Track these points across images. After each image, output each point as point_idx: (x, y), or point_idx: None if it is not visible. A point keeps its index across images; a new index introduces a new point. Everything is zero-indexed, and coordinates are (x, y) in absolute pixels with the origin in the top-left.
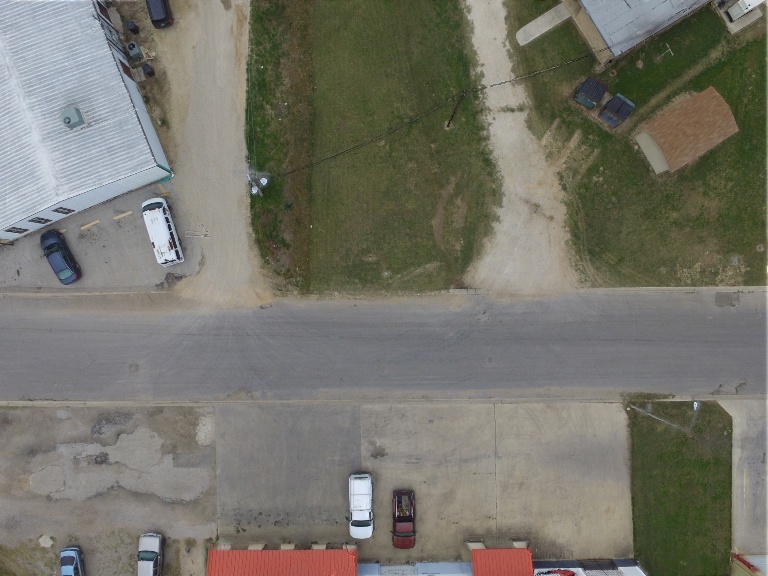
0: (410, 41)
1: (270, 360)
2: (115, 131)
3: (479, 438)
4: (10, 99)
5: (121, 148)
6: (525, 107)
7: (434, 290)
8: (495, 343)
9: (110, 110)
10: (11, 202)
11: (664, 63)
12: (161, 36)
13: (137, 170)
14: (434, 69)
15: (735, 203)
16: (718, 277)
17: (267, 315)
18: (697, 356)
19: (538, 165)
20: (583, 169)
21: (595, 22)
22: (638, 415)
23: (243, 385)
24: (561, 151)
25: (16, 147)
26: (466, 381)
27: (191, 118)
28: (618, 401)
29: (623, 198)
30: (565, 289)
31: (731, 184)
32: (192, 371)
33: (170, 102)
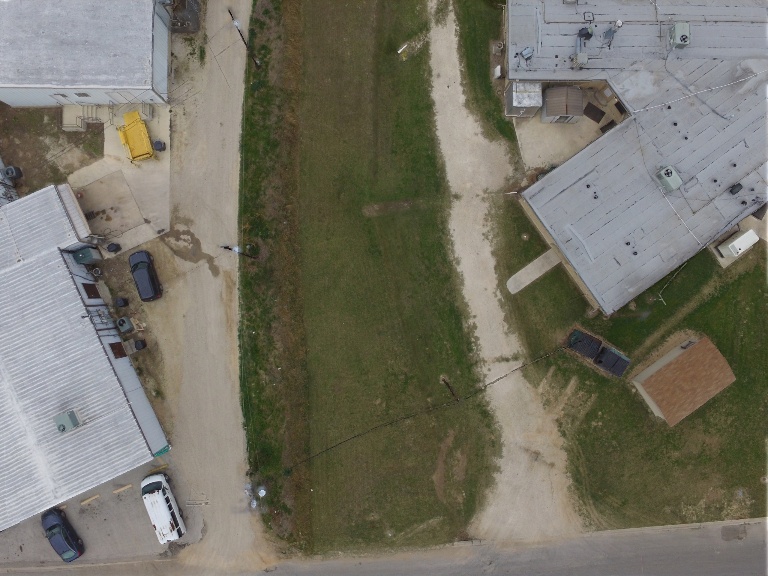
0: (400, 296)
1: None
2: (110, 427)
3: None
4: (3, 402)
5: (117, 444)
6: (520, 356)
7: (438, 544)
8: None
9: (104, 406)
10: (10, 505)
11: (657, 303)
12: (151, 306)
13: (134, 466)
14: (426, 323)
15: (736, 437)
16: (723, 512)
17: None
18: None
19: (536, 413)
20: (581, 415)
21: (586, 282)
22: None
23: None
24: (558, 398)
25: (12, 449)
26: None
27: (185, 387)
28: None
29: (623, 441)
30: (570, 534)
31: (731, 419)
32: None
33: (163, 372)
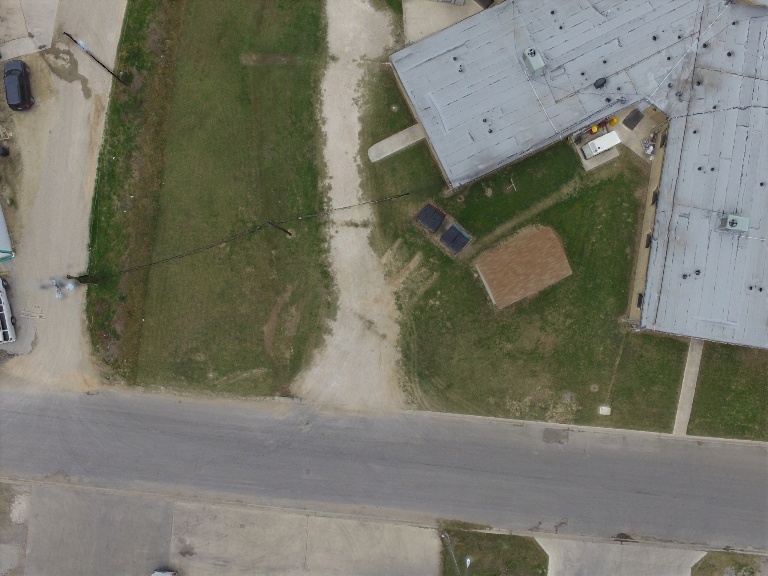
0: (263, 146)
1: (91, 447)
2: None
3: (289, 548)
4: None
5: None
6: (369, 223)
7: (259, 395)
8: (315, 455)
9: None
10: None
11: (513, 194)
12: (20, 117)
13: None
14: (283, 176)
15: (572, 341)
16: (548, 413)
17: (93, 402)
18: (519, 490)
19: (376, 282)
20: (420, 291)
21: (437, 152)
22: (452, 543)
23: (62, 468)
24: (400, 271)
25: None
26: (282, 490)
27: (39, 201)
28: (434, 527)
29: (458, 324)
30: (391, 409)
31: (570, 321)
32: (14, 448)
33: (21, 183)
